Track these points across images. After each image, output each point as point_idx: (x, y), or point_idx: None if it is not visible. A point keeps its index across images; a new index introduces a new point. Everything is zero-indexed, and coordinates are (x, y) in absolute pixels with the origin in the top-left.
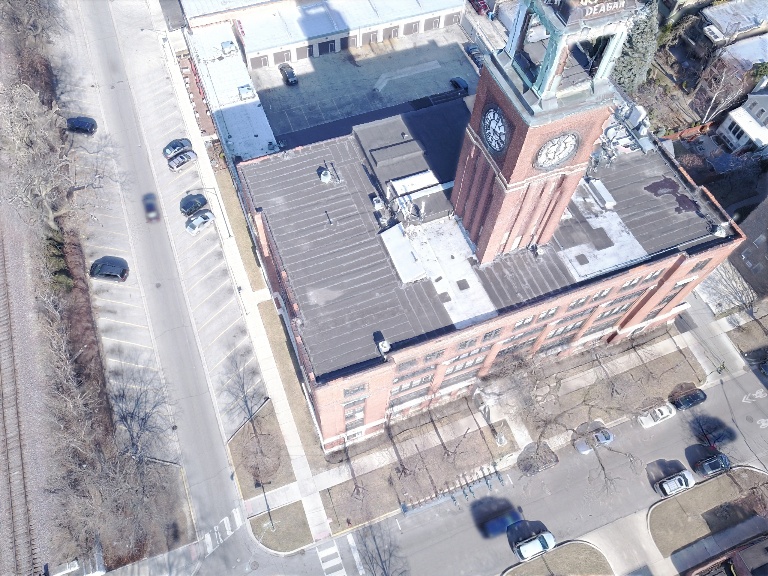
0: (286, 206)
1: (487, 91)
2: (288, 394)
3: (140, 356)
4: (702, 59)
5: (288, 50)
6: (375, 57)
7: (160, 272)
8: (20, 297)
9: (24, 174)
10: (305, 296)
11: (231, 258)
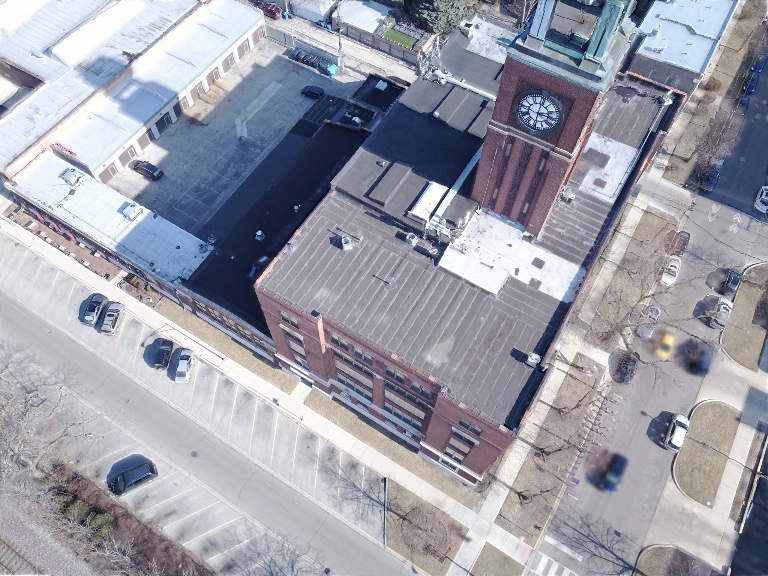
0: (335, 294)
1: (518, 81)
2: (399, 462)
3: (236, 533)
4: None
5: (130, 146)
6: (215, 108)
7: (184, 440)
8: (67, 573)
9: (2, 444)
10: (427, 363)
11: (242, 379)
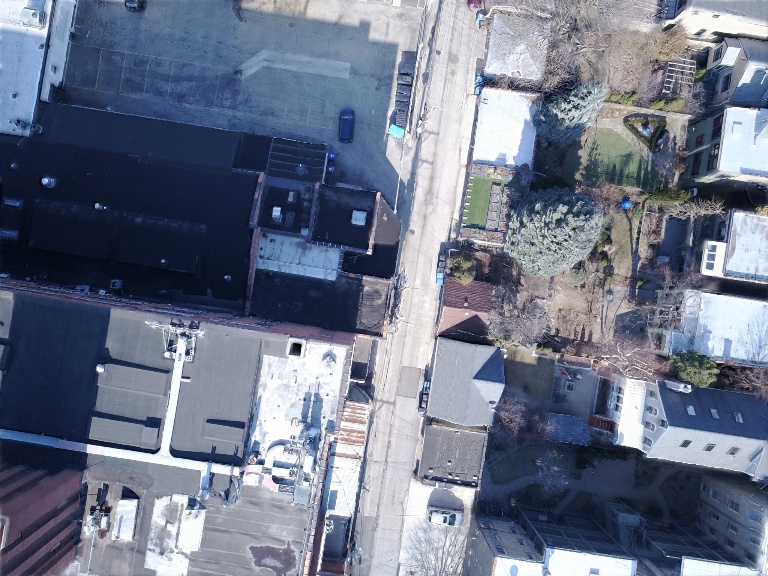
0: None
1: None
2: None
3: None
4: (681, 273)
5: None
6: (271, 14)
7: None
8: None
9: None
10: None
11: None
